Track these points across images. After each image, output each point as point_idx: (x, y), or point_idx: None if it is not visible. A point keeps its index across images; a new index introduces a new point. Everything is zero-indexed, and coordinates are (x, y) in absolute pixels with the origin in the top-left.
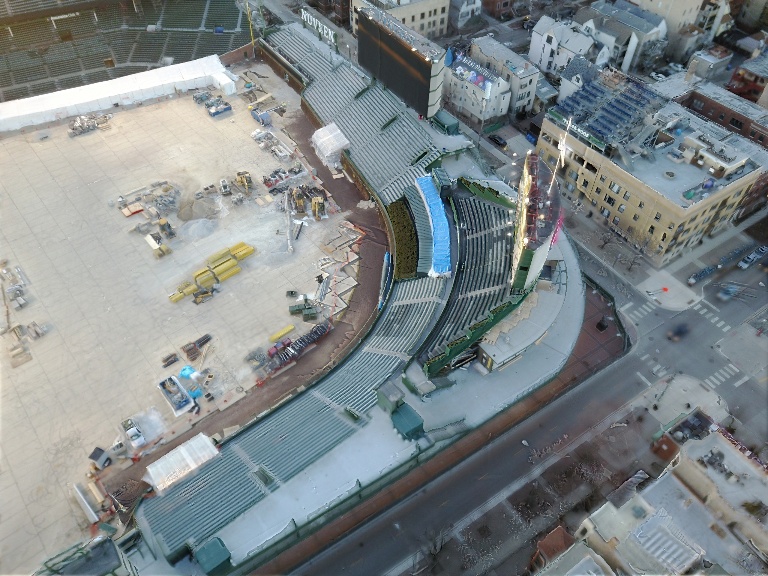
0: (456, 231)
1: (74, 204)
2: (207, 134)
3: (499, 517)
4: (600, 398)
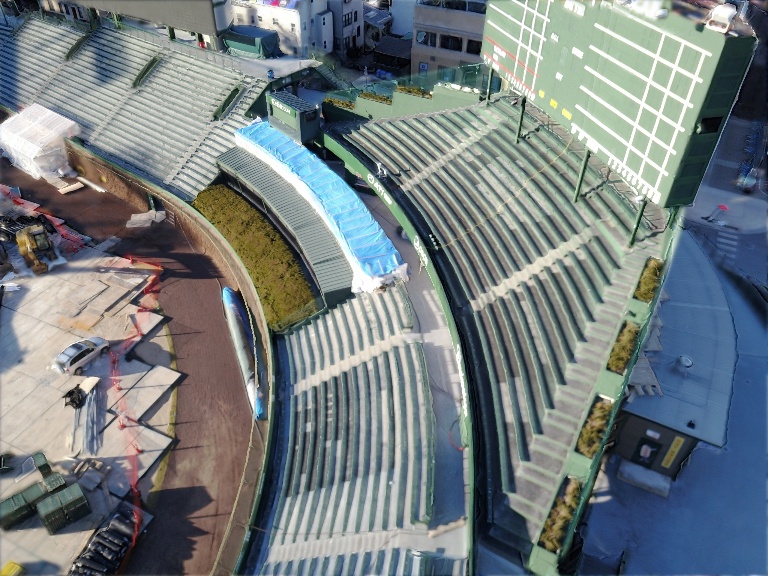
0: (362, 195)
1: None
2: None
3: None
4: None
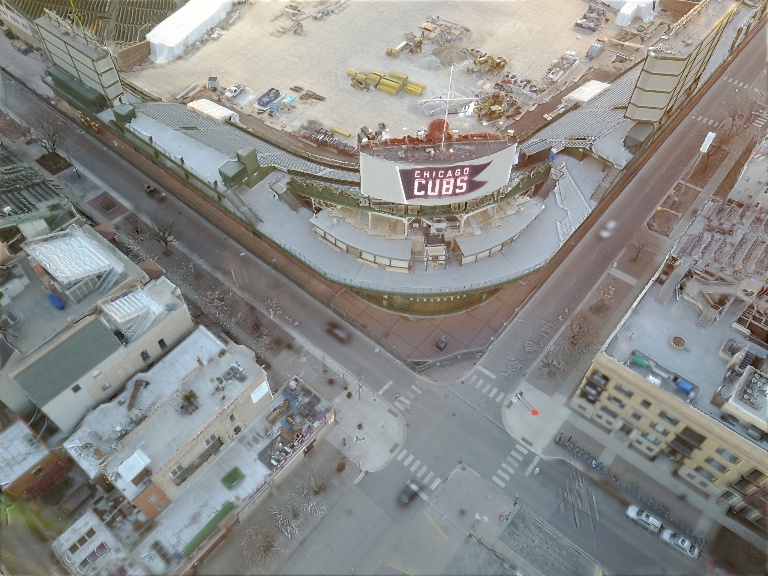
0: None
1: (419, 3)
2: (548, 31)
3: (212, 284)
4: (348, 349)
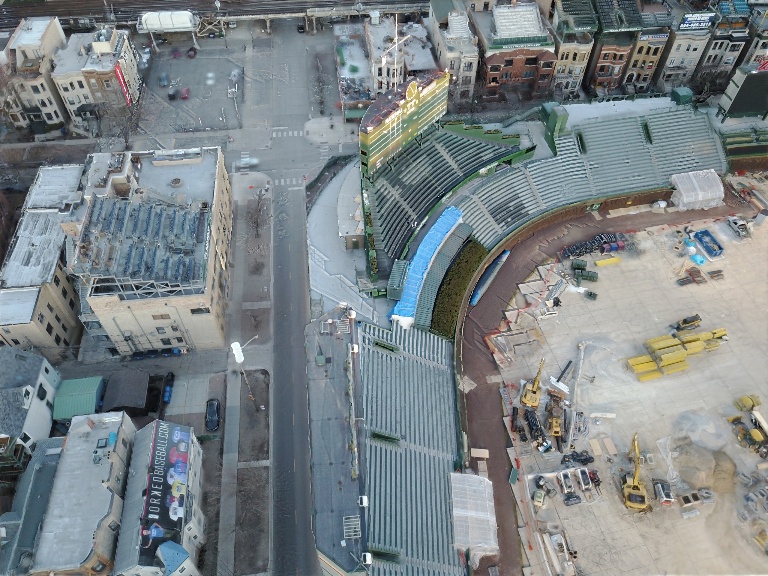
0: None
1: None
2: None
3: None
4: None
